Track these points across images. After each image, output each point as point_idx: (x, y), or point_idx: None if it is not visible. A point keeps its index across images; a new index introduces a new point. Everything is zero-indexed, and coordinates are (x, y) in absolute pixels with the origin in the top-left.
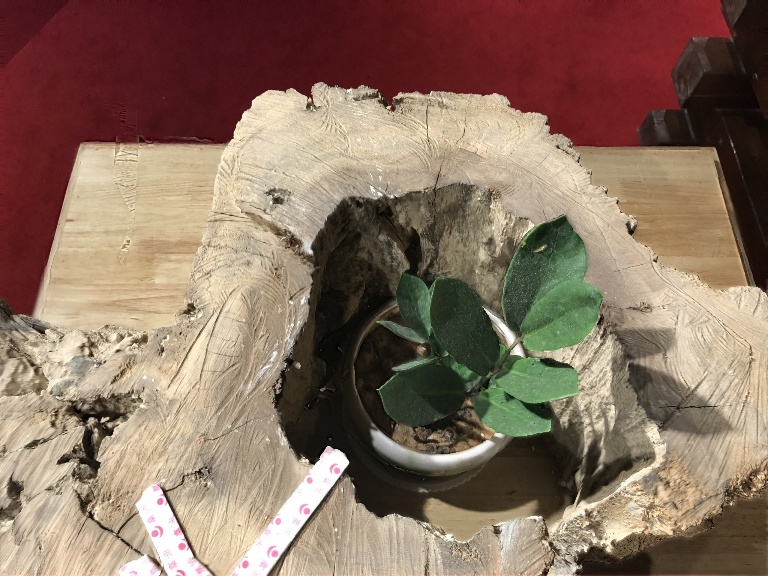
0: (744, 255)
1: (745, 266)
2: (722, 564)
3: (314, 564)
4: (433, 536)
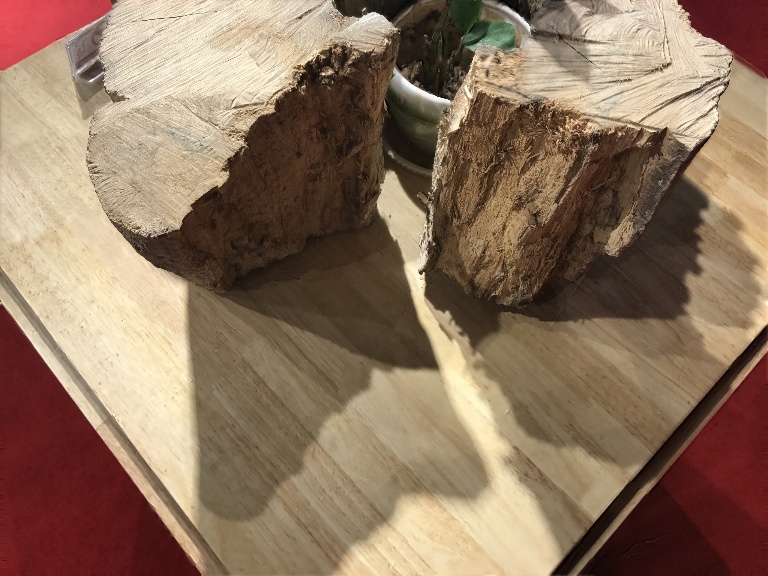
0: None
1: None
2: (549, 382)
3: None
4: None
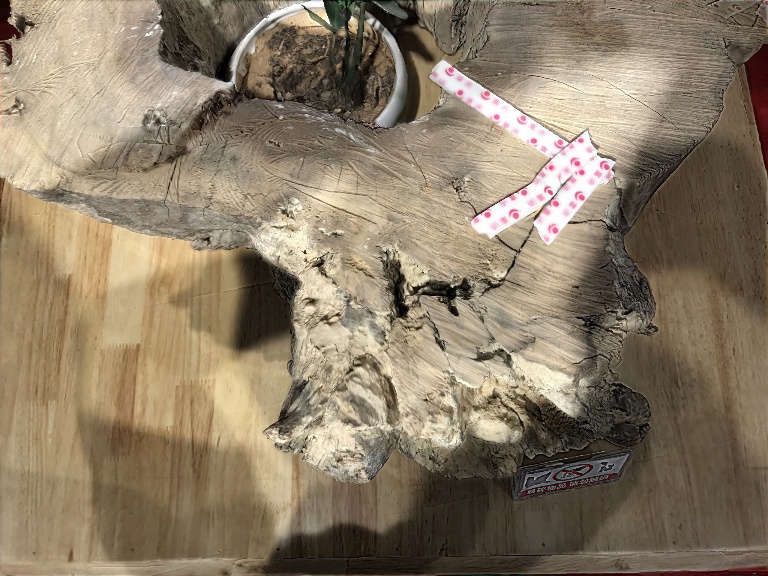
0: None
1: None
2: None
3: (528, 90)
4: None
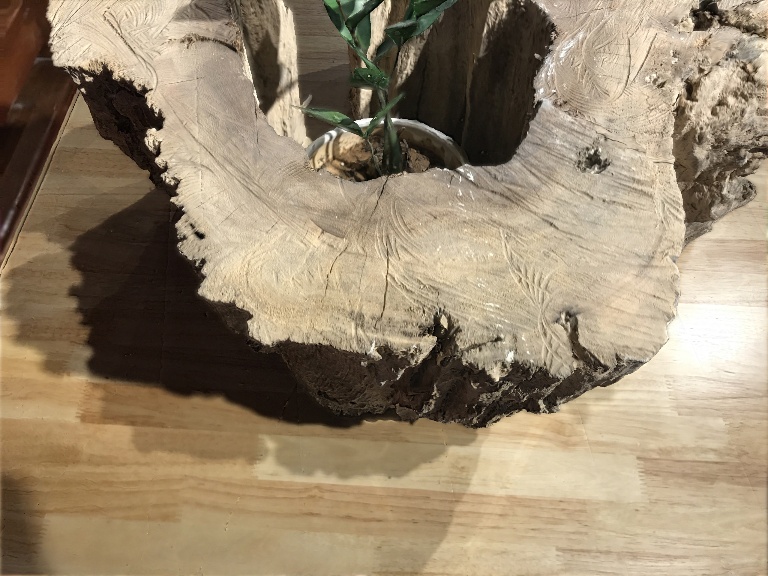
0: None
1: None
2: None
3: None
4: None
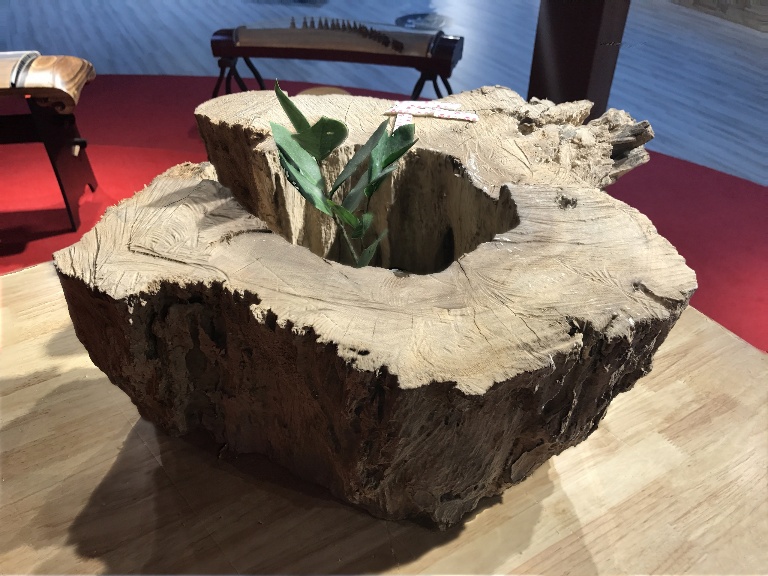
0: None
1: None
2: (88, 408)
3: None
4: None
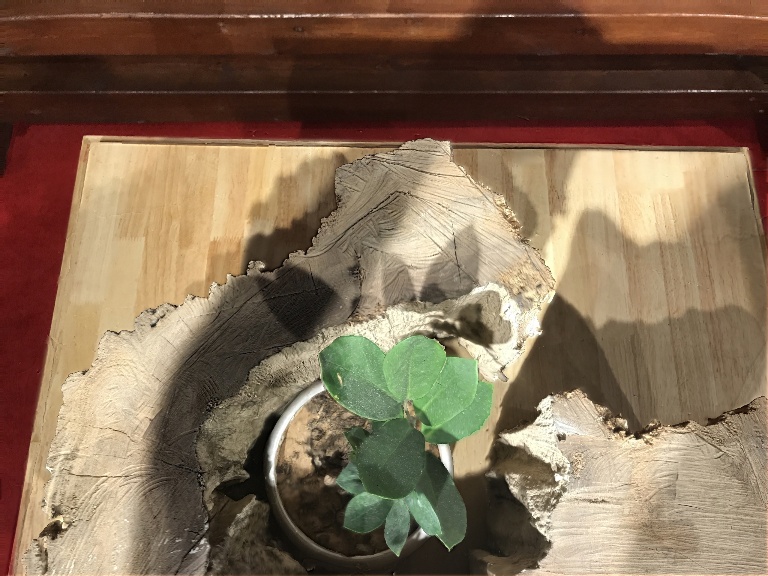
0: (215, 141)
1: (227, 143)
2: None
3: None
4: (566, 494)
